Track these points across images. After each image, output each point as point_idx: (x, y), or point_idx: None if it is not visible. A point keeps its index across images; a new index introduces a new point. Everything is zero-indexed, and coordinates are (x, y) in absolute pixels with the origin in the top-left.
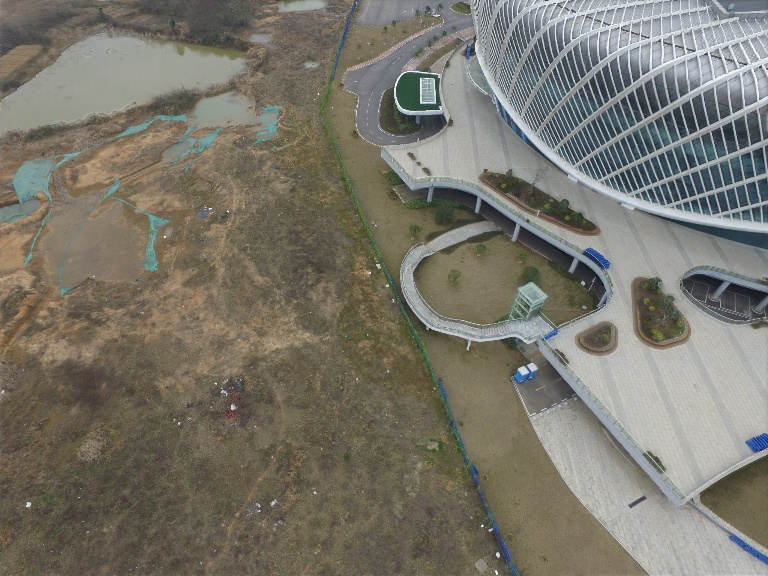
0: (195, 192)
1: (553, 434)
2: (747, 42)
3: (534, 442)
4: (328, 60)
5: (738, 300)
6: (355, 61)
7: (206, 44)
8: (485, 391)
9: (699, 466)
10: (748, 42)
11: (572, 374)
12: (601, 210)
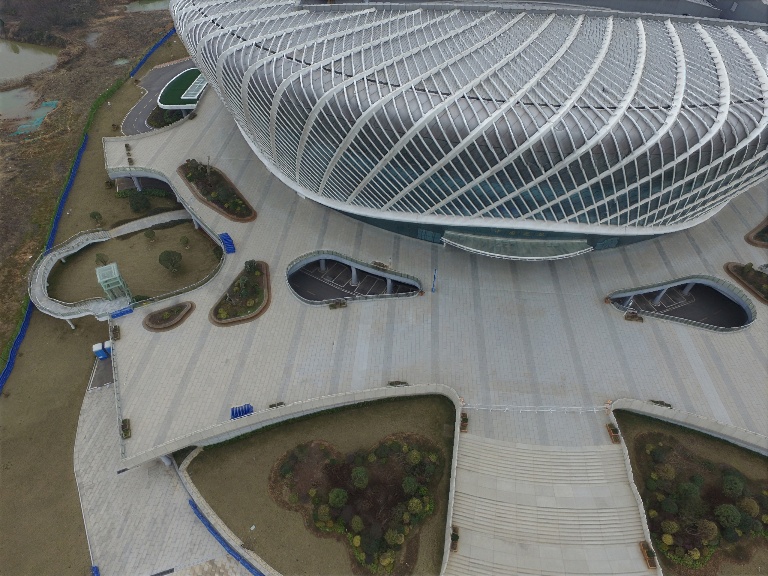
0: None
1: (98, 406)
2: None
3: (72, 413)
4: (138, 58)
5: (376, 285)
6: (167, 59)
7: (32, 42)
8: (59, 366)
9: (168, 433)
10: (292, 33)
11: (115, 349)
12: (273, 198)
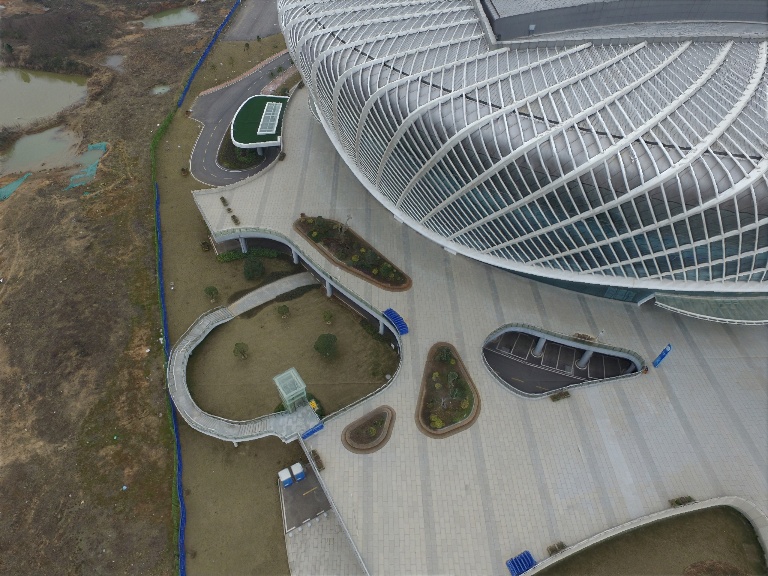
0: None
1: (307, 555)
2: (508, 79)
3: (281, 570)
4: (180, 84)
5: (562, 354)
6: (211, 83)
7: (48, 70)
8: (240, 503)
9: None
10: (509, 79)
11: (324, 483)
12: (420, 257)
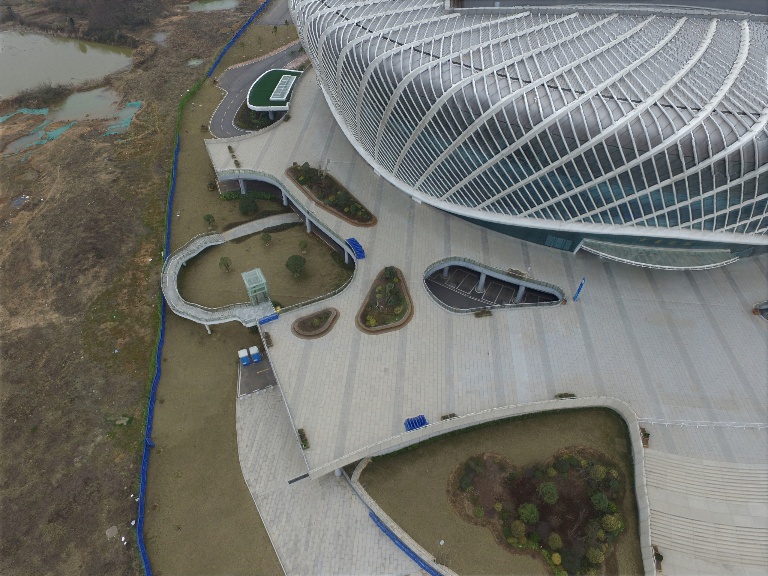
0: (20, 181)
1: (252, 414)
2: (451, 37)
3: (228, 420)
4: (212, 58)
5: (502, 292)
6: (239, 59)
7: (102, 42)
8: (205, 372)
9: (346, 444)
10: (451, 37)
11: (270, 356)
12: (389, 203)
